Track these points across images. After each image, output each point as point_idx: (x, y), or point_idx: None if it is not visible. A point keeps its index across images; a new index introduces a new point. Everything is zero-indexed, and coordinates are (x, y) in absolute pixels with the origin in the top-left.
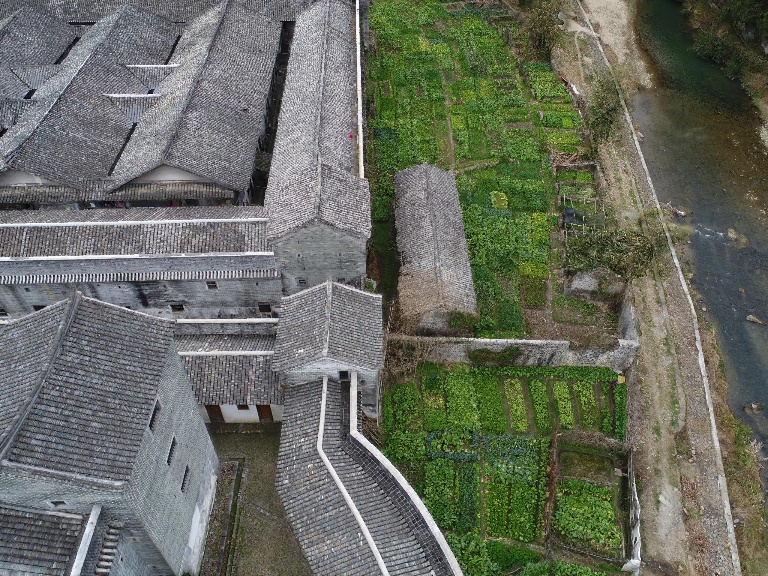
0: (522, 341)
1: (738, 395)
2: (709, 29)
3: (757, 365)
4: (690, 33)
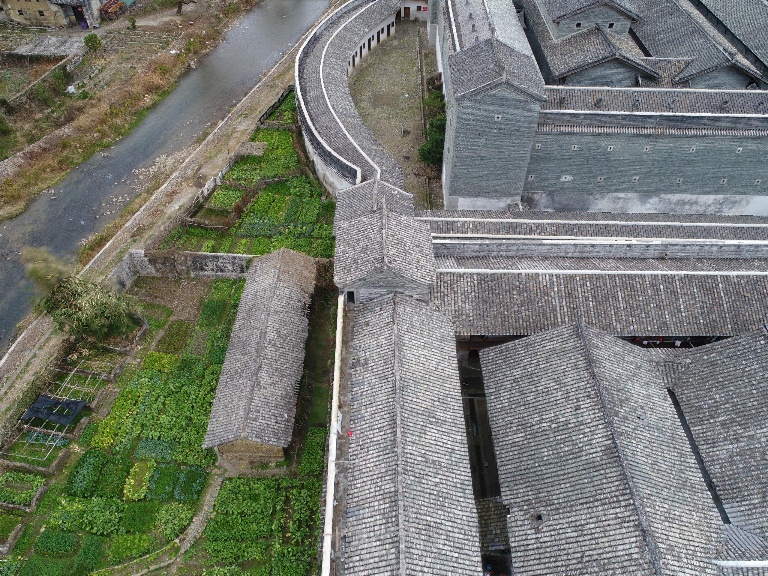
0: (222, 253)
1: (52, 286)
2: None
3: (8, 308)
4: None
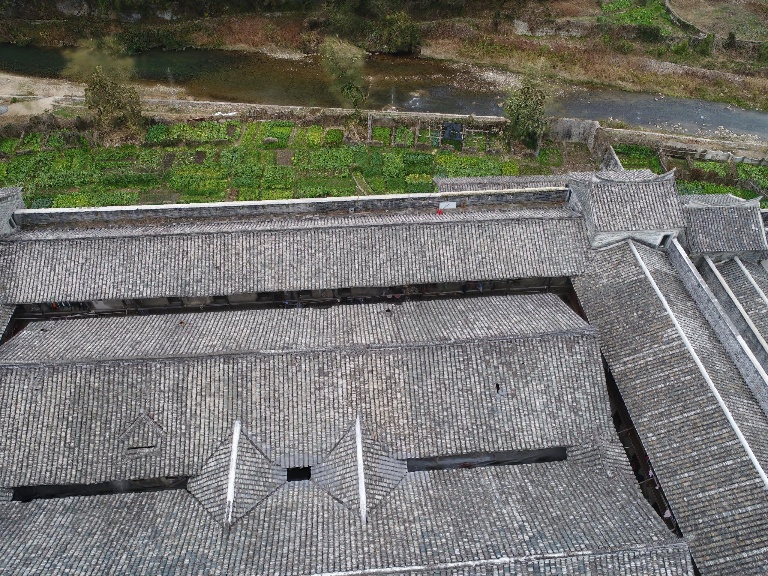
0: None
1: None
2: (75, 39)
3: None
4: (70, 51)
